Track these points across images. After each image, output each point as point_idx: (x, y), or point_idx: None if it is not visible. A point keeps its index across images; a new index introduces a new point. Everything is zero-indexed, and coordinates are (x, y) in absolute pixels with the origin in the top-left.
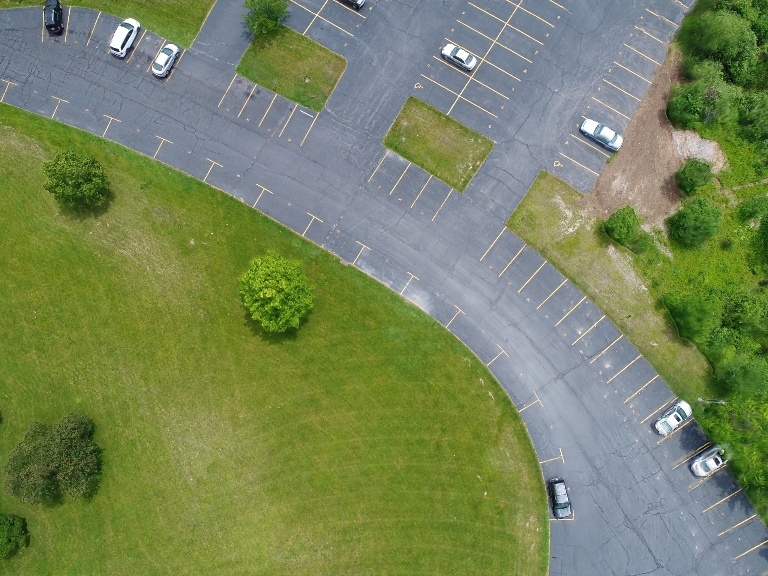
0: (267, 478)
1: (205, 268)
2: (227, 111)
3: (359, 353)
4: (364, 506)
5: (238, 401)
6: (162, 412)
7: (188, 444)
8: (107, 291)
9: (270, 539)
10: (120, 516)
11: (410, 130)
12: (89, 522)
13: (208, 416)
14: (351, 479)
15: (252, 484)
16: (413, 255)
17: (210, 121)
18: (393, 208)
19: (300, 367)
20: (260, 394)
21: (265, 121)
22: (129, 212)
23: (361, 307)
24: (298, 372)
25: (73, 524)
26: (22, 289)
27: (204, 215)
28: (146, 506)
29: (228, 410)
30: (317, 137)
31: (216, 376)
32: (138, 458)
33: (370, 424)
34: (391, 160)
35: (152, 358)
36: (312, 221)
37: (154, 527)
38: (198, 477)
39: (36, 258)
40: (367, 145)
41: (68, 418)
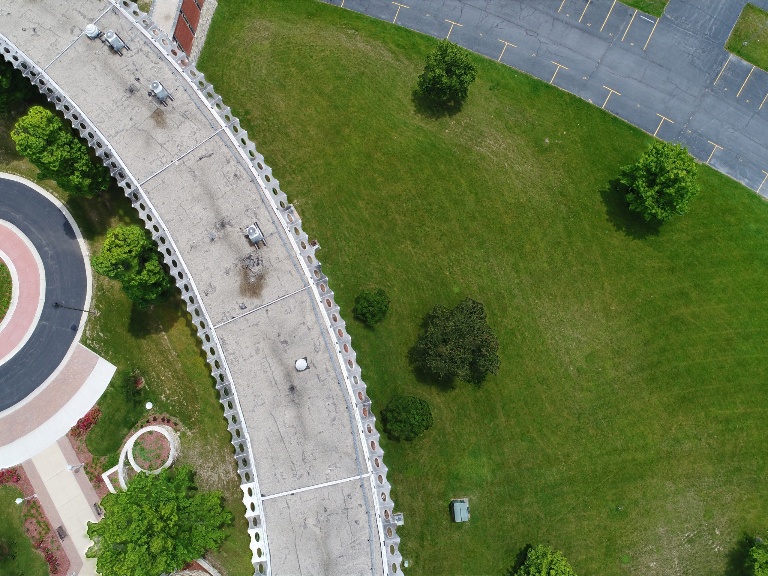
0: (645, 368)
1: (562, 166)
2: (567, 16)
3: (723, 248)
4: (743, 396)
5: (608, 293)
6: (536, 303)
7: (564, 334)
8: (470, 186)
9: (654, 427)
10: (509, 402)
11: (750, 35)
12: (481, 407)
13: (580, 308)
14: (728, 370)
15: (631, 374)
16: (766, 154)
17: (551, 26)
18: (741, 109)
19: (666, 261)
20: (629, 287)
21: (606, 26)
22: (481, 112)
23: (720, 204)
24: (664, 266)
25: (467, 409)
26: (390, 183)
27: (555, 115)
28: (532, 393)
29: (599, 302)
30: (659, 41)
31: (584, 269)
32: (519, 347)
33: (741, 316)
34: (735, 63)
35: (521, 251)
36: (662, 121)
37: (542, 414)
38: (578, 366)
39: (399, 153)
40: (709, 49)
41: (471, 299)
